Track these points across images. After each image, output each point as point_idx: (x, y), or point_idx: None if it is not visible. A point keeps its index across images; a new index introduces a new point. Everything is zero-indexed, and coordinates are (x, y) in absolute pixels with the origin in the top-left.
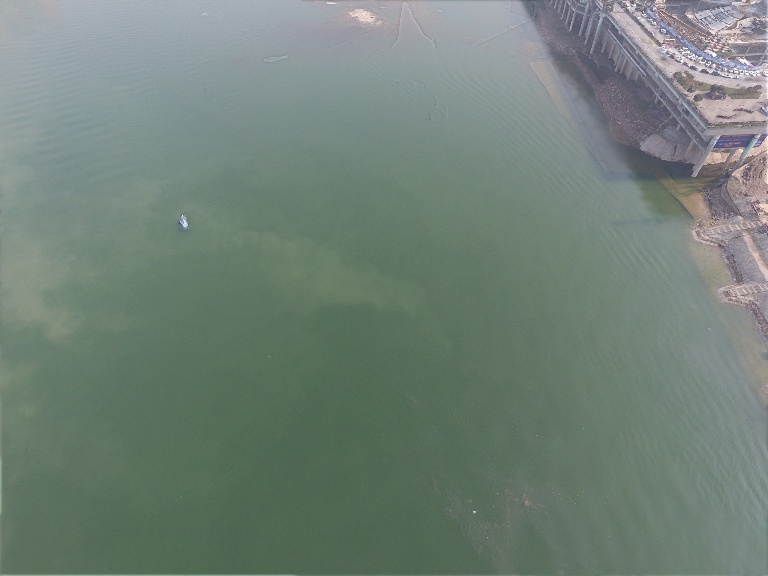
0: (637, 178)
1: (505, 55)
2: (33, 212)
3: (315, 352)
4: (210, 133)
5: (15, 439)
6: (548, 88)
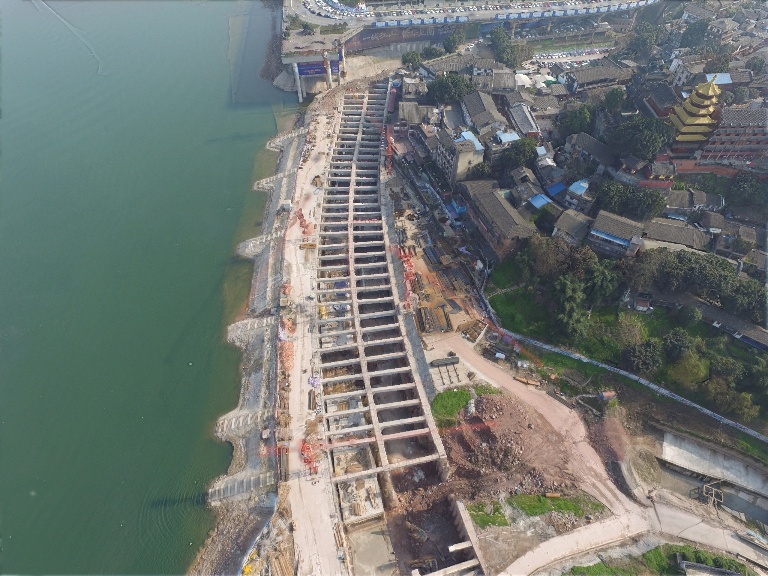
0: (255, 106)
1: (214, 13)
2: None
3: None
4: None
5: None
6: (232, 39)
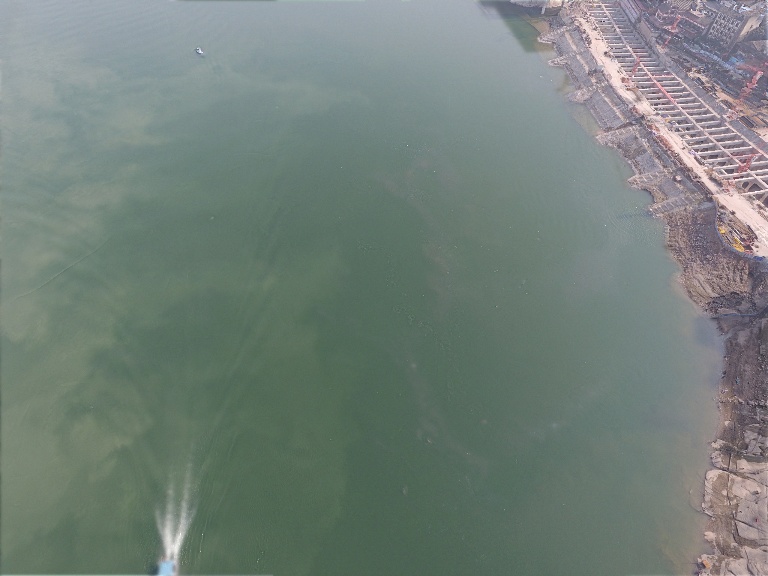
0: (507, 16)
1: None
2: (79, 58)
3: (306, 103)
4: (202, 5)
5: (124, 151)
6: None
